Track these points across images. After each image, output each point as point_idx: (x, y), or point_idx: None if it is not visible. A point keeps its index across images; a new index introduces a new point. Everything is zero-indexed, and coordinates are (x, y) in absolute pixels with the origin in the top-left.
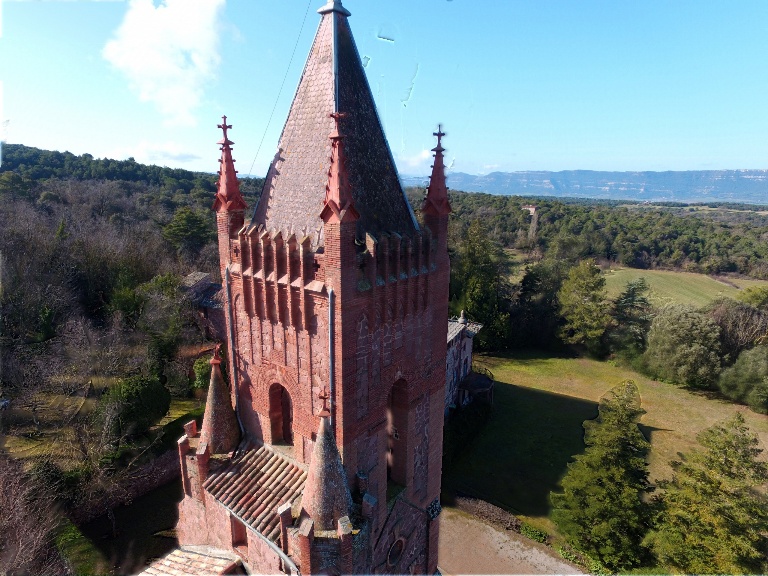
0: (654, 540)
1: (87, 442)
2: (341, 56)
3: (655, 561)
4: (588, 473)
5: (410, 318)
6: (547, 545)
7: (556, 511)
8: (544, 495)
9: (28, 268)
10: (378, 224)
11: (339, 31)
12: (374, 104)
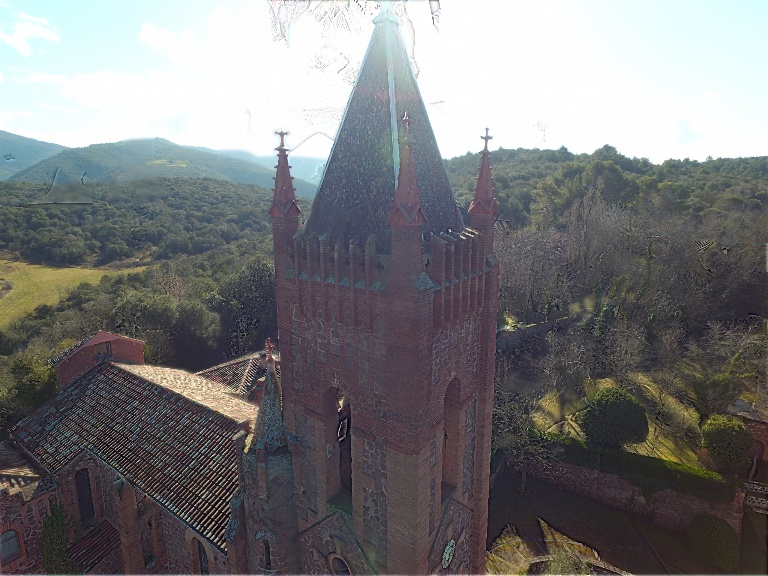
0: None
1: (532, 408)
2: (368, 66)
3: None
4: None
5: (351, 332)
6: None
7: None
8: None
9: (659, 274)
10: (348, 227)
11: (375, 41)
12: (392, 102)
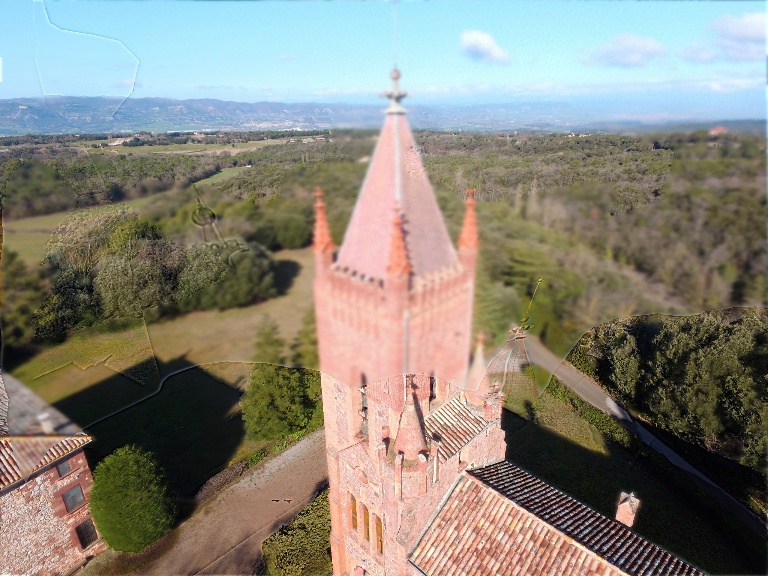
0: (313, 392)
1: None
2: None
3: (314, 403)
4: (269, 388)
5: None
6: (267, 456)
7: (250, 435)
8: (215, 443)
9: None
10: None
11: None
12: None
